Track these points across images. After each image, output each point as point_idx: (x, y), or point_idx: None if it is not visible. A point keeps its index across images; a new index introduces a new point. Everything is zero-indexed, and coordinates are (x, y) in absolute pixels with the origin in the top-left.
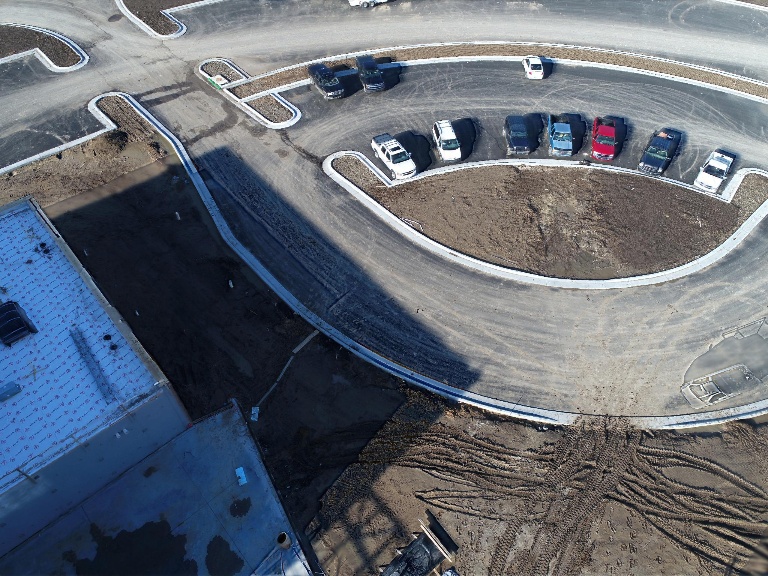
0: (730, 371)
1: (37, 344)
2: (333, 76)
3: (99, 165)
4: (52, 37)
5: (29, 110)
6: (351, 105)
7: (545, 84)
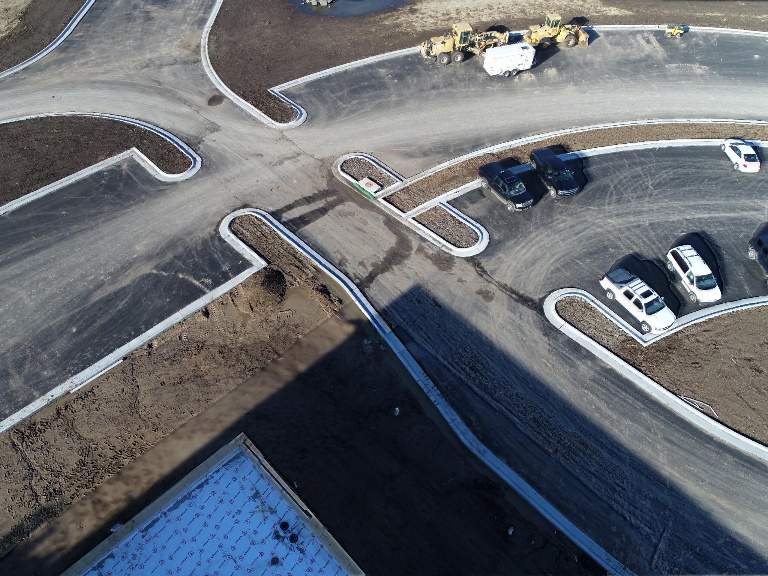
0: None
1: None
2: (518, 181)
3: (262, 325)
4: (148, 131)
5: (147, 241)
6: (543, 217)
7: (762, 178)
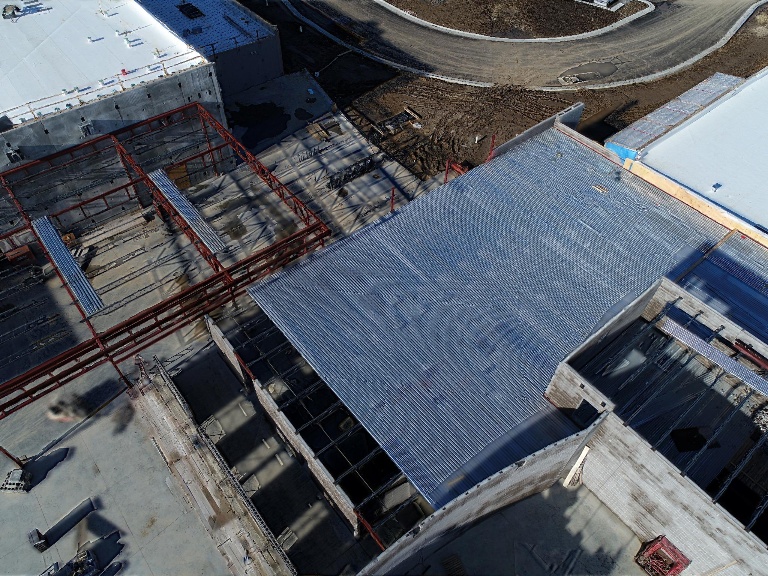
0: (588, 74)
1: (207, 20)
2: None
3: None
4: None
5: None
6: None
7: None
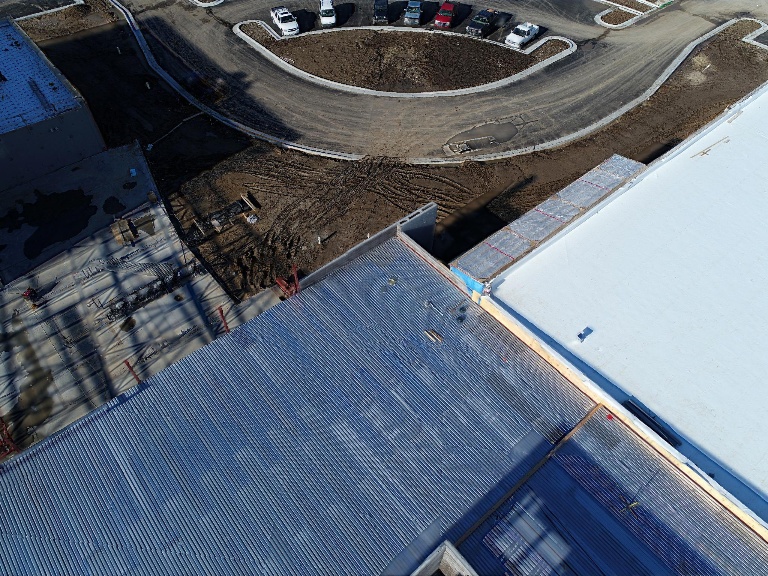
0: (481, 139)
1: (6, 86)
2: None
3: (68, 24)
4: None
5: None
6: None
7: None
